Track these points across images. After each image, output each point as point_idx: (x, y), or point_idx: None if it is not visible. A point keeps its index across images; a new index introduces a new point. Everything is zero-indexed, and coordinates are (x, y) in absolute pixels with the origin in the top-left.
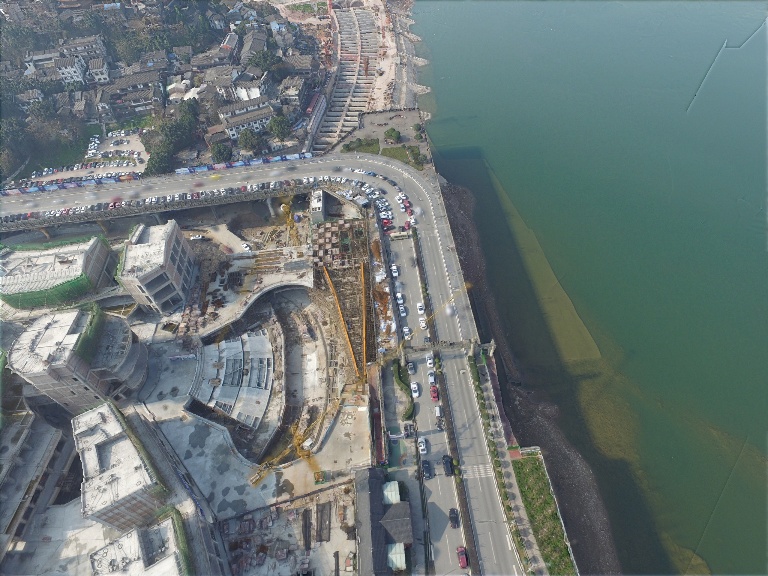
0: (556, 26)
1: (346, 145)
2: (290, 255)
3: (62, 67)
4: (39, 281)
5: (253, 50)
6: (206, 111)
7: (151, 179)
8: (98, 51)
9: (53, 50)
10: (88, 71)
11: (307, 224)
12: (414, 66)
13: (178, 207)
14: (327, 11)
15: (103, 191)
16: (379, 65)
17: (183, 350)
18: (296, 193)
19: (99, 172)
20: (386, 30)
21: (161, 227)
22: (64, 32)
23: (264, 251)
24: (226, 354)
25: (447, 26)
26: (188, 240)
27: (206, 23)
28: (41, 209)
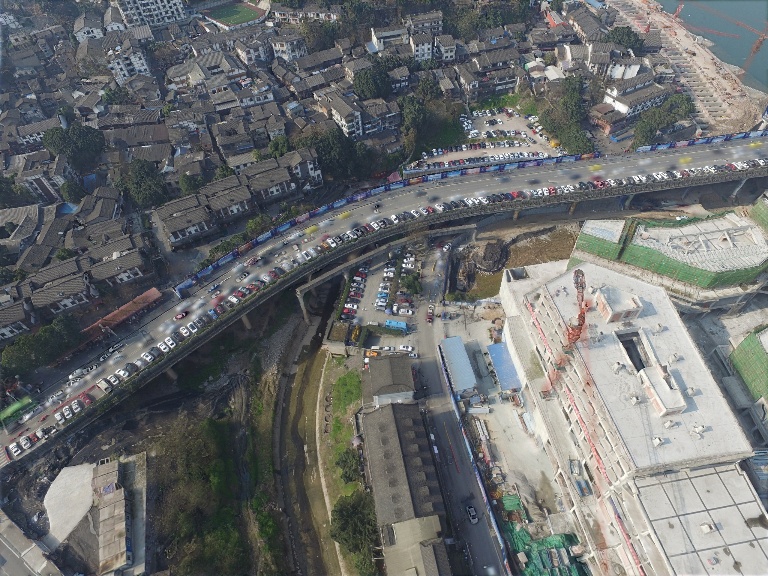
0: None
1: None
2: None
3: (420, 44)
4: (731, 258)
5: (602, 27)
6: (583, 89)
7: (611, 157)
8: (441, 28)
9: (397, 26)
10: (434, 49)
11: None
12: None
13: (678, 185)
14: None
15: (568, 170)
16: (681, 45)
17: None
18: None
19: (494, 152)
20: (652, 11)
21: None
22: (400, 8)
23: None
24: None
25: (697, 7)
26: (674, 221)
27: None
28: (519, 188)
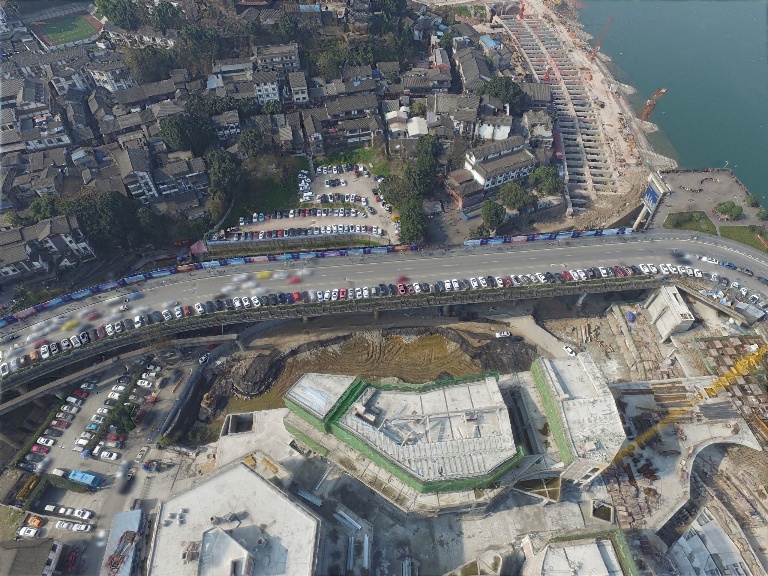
0: (761, 53)
1: (677, 221)
2: (698, 392)
3: (261, 83)
4: (458, 456)
5: (483, 74)
6: (443, 150)
7: (432, 251)
8: (295, 63)
9: (243, 59)
10: (284, 88)
11: (647, 326)
12: (624, 95)
13: (494, 299)
14: (485, 16)
15: (375, 264)
16: (592, 93)
17: (647, 558)
18: (642, 288)
19: (323, 223)
20: (576, 47)
21: (567, 361)
22: (251, 36)
23: (657, 383)
24: (700, 563)
25: (632, 44)
26: (493, 337)
27: (411, 34)
28: (306, 287)
